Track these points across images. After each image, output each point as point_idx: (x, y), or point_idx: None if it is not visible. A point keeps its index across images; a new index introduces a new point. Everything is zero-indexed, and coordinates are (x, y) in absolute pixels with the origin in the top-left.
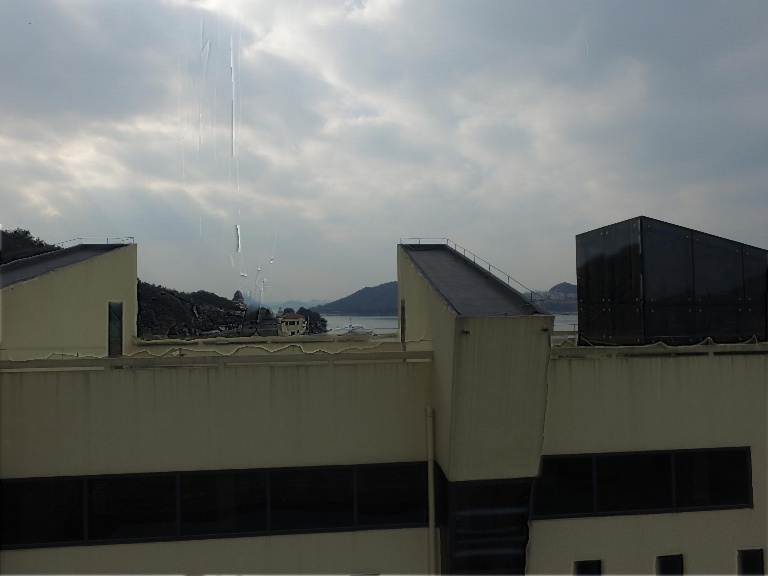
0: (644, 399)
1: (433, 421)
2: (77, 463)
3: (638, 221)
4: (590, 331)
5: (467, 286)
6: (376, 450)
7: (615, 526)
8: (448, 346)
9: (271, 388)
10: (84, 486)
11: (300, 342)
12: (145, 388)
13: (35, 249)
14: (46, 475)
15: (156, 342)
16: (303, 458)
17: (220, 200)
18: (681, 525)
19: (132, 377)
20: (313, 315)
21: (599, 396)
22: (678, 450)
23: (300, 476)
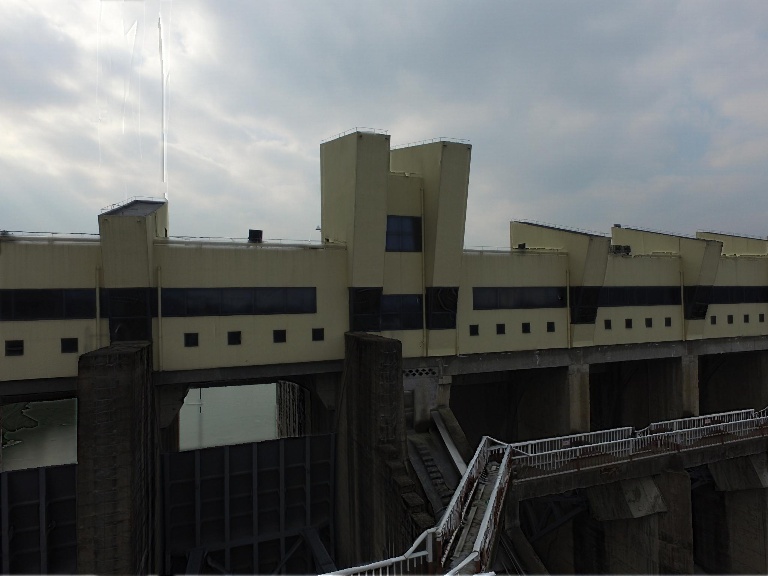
0: None
1: None
2: None
3: None
4: None
5: None
6: None
7: None
8: None
9: None
10: None
11: None
12: None
13: None
14: None
15: None
16: None
17: (145, 190)
18: None
19: None
20: None
21: None
22: None
23: None
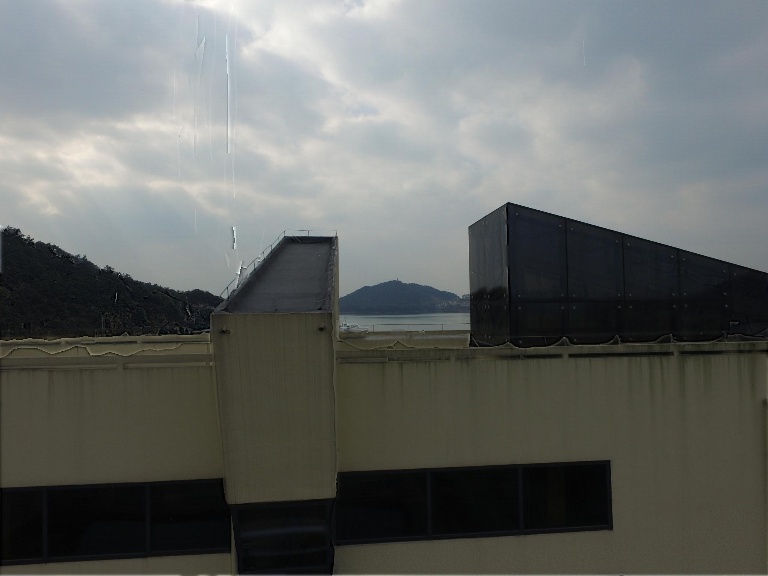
0: (488, 407)
1: None
2: None
3: (505, 208)
4: (479, 330)
5: (301, 280)
6: (173, 465)
7: (452, 550)
8: None
9: (49, 395)
10: None
11: (173, 342)
12: None
13: (25, 247)
14: None
15: (14, 342)
16: (86, 475)
17: (216, 198)
18: (529, 549)
19: None
20: None
21: (435, 404)
22: (526, 464)
23: (82, 495)
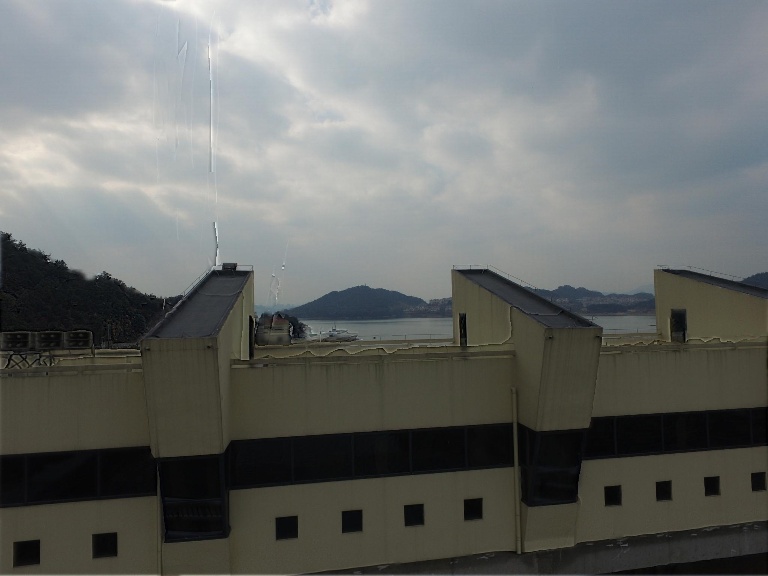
0: None
1: None
2: (610, 409)
3: None
4: None
5: None
6: (760, 399)
7: None
8: None
9: (708, 363)
10: (614, 422)
11: None
12: (643, 364)
13: (19, 253)
14: (597, 416)
15: None
16: (725, 404)
17: (197, 203)
18: None
19: (637, 357)
20: (293, 320)
21: None
22: None
23: (724, 415)
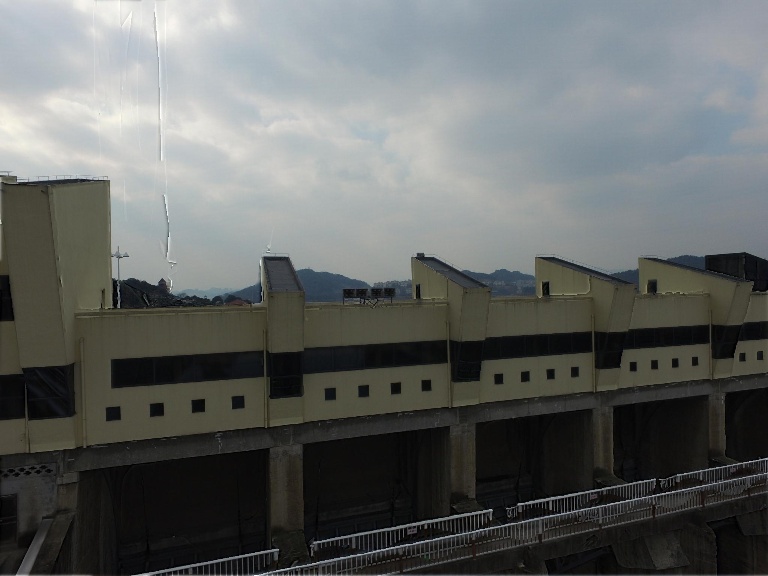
0: (755, 307)
1: (711, 313)
2: (632, 326)
3: (743, 254)
4: None
5: None
6: (697, 322)
7: (748, 343)
8: (732, 290)
9: (674, 304)
10: (634, 332)
11: None
12: (647, 304)
13: None
14: None
15: None
16: (681, 324)
17: None
18: (762, 343)
19: (644, 301)
20: None
21: None
22: (762, 322)
23: (681, 329)
